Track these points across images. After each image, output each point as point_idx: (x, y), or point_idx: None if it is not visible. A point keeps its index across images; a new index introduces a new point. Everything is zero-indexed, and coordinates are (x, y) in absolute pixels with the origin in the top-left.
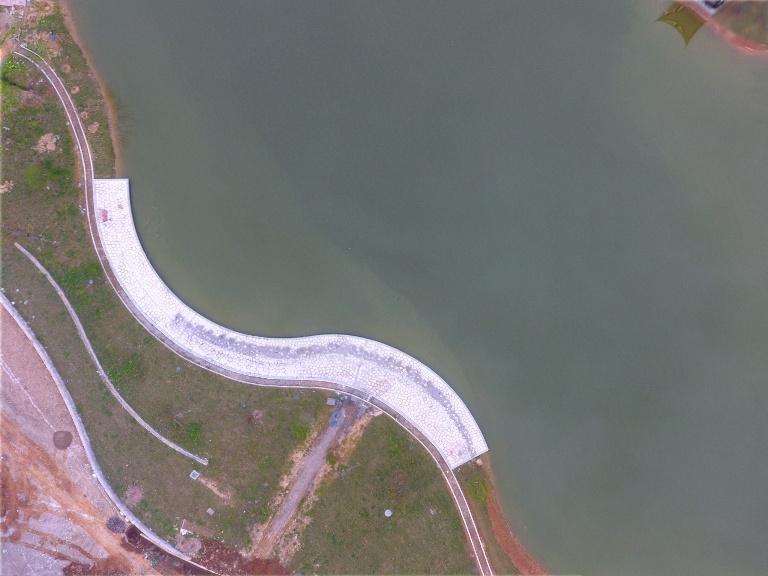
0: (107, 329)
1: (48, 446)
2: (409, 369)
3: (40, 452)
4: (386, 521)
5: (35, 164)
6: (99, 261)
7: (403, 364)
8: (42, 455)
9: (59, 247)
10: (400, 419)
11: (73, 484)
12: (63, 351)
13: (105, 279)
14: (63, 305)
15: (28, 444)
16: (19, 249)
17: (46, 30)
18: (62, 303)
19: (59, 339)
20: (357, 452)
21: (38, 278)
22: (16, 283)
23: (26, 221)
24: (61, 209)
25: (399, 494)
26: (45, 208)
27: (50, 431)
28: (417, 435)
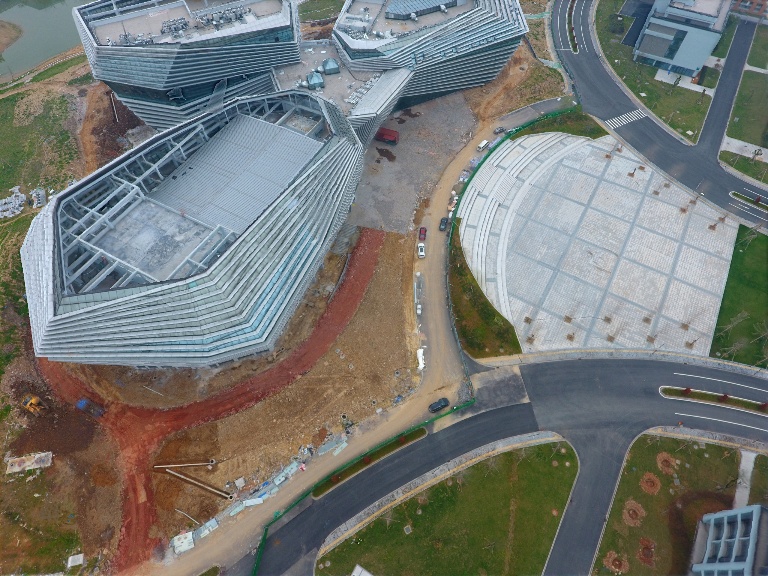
0: None
1: None
2: None
3: None
4: None
5: None
6: None
7: None
8: None
9: None
10: None
11: None
12: None
13: None
14: None
15: None
16: None
17: None
18: None
19: None
20: None
21: None
22: None
23: None
24: None
25: None
26: None
27: None
28: None
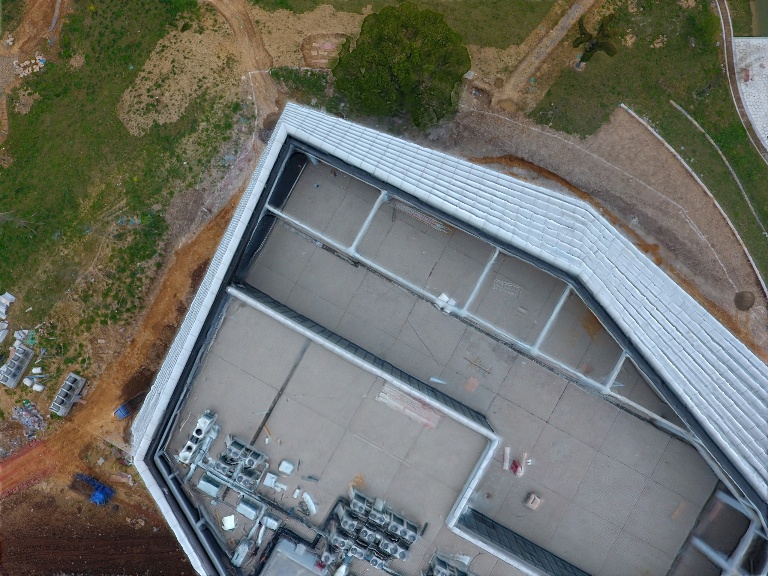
0: (761, 191)
1: (729, 307)
2: None
3: (720, 314)
4: None
5: (682, 19)
6: (741, 122)
7: None
8: (722, 317)
9: (710, 106)
10: None
11: (757, 346)
12: (732, 211)
13: (749, 141)
14: (724, 164)
15: (707, 305)
16: (675, 107)
17: None
18: (723, 162)
19: (728, 198)
20: None
21: (698, 136)
22: (680, 140)
23: (680, 78)
24: (706, 67)
25: None
26: (694, 65)
27: (731, 292)
28: None
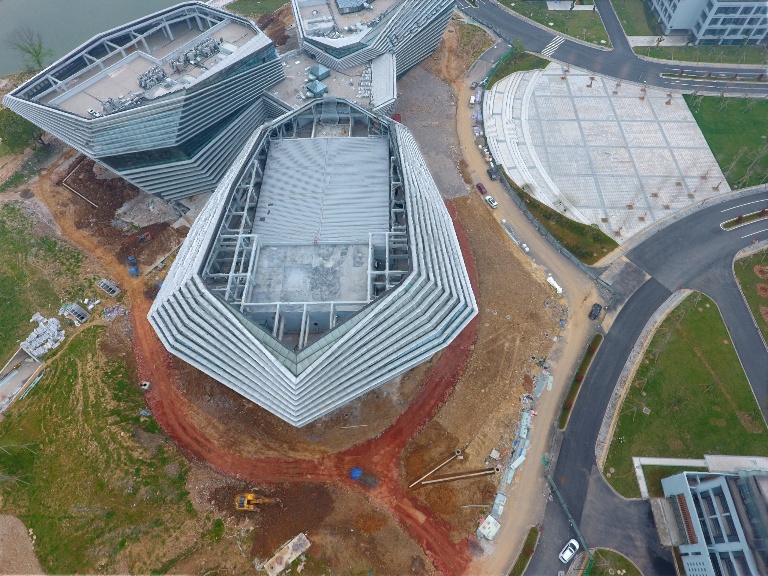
0: None
1: None
2: (213, 1)
3: None
4: (261, 2)
5: None
6: None
7: (211, 2)
8: None
9: None
10: (229, 3)
11: None
12: None
13: None
14: None
15: None
16: None
17: (25, 74)
18: None
19: None
20: (235, 9)
21: None
22: None
23: None
24: None
25: (254, 1)
26: None
27: None
28: (237, 0)
